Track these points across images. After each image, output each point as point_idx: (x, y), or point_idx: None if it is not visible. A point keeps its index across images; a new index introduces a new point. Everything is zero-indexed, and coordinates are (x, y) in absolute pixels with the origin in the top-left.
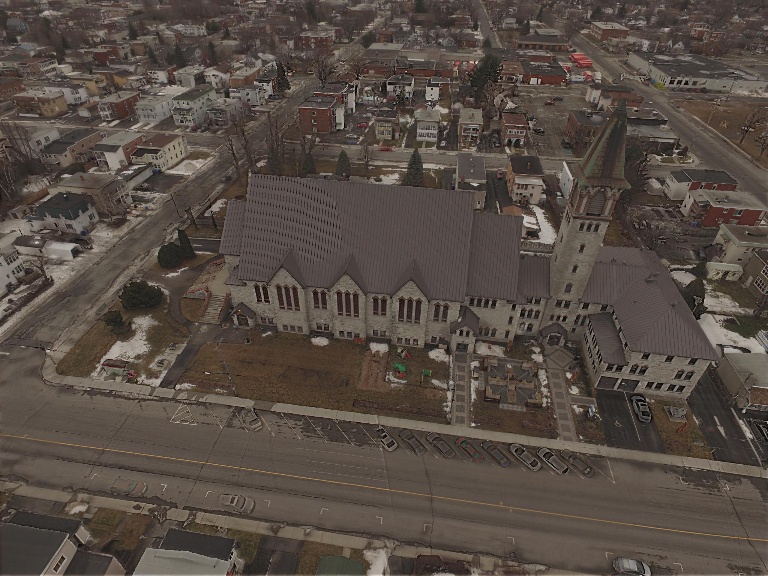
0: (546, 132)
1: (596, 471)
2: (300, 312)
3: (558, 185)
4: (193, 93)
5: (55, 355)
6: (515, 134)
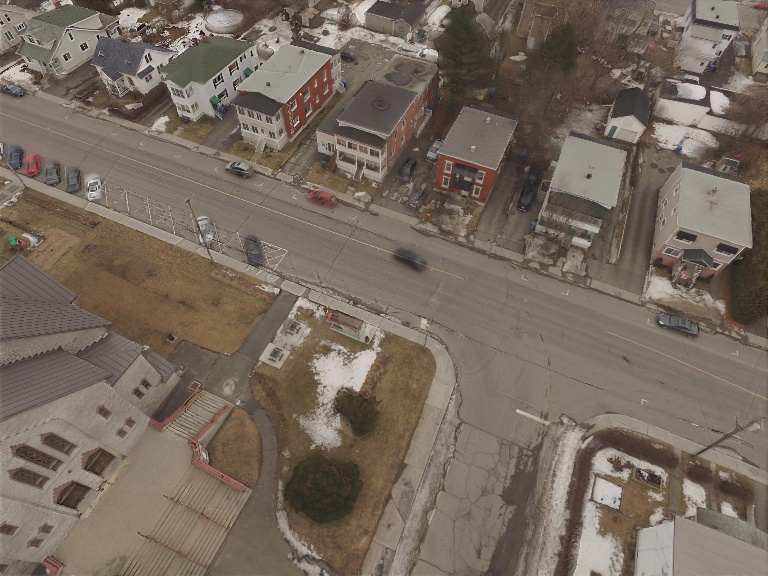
0: None
1: None
2: None
3: None
4: None
5: (446, 388)
6: None
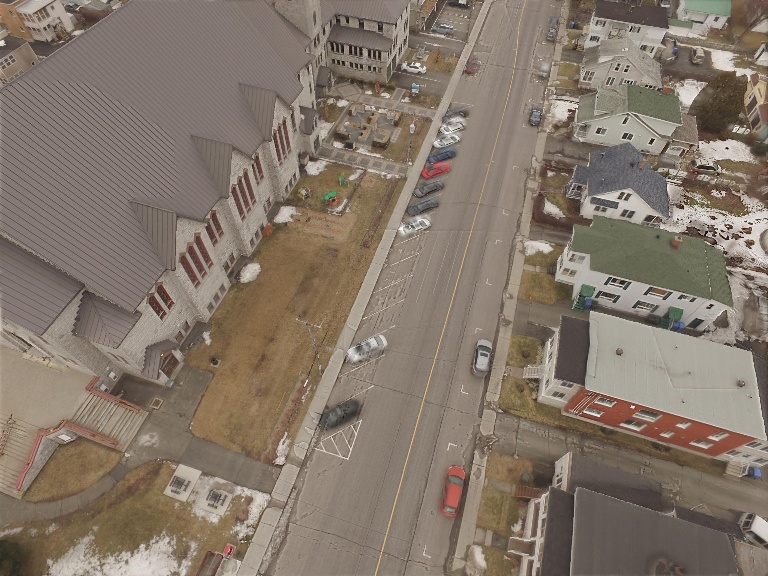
0: None
1: (463, 110)
2: (214, 265)
3: None
4: None
5: None
6: None
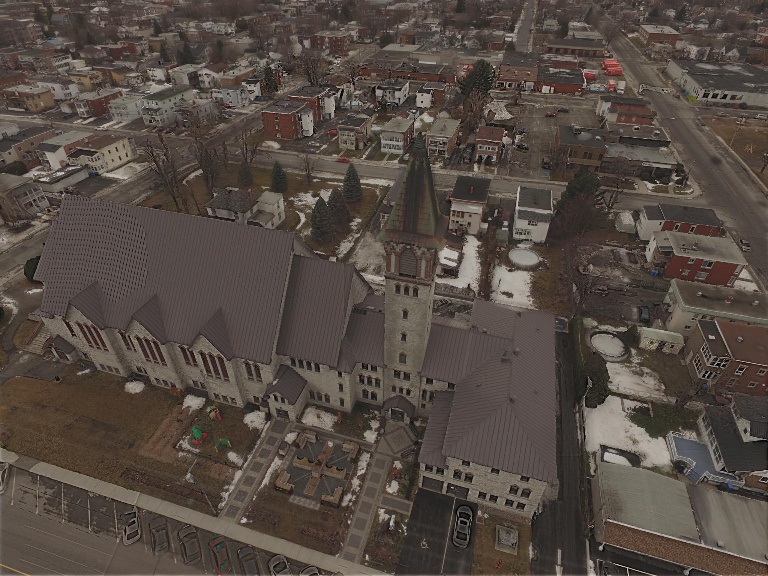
0: (530, 148)
1: None
2: (109, 353)
3: (513, 213)
4: (166, 93)
5: None
6: (486, 150)
